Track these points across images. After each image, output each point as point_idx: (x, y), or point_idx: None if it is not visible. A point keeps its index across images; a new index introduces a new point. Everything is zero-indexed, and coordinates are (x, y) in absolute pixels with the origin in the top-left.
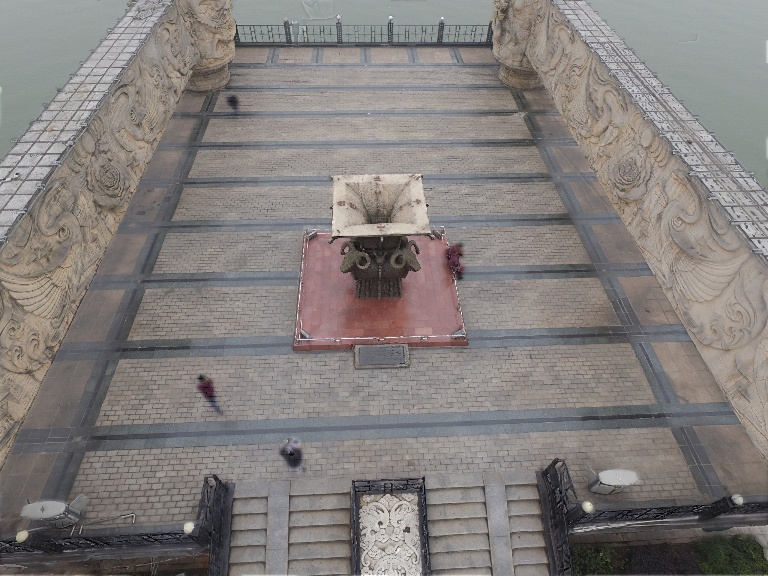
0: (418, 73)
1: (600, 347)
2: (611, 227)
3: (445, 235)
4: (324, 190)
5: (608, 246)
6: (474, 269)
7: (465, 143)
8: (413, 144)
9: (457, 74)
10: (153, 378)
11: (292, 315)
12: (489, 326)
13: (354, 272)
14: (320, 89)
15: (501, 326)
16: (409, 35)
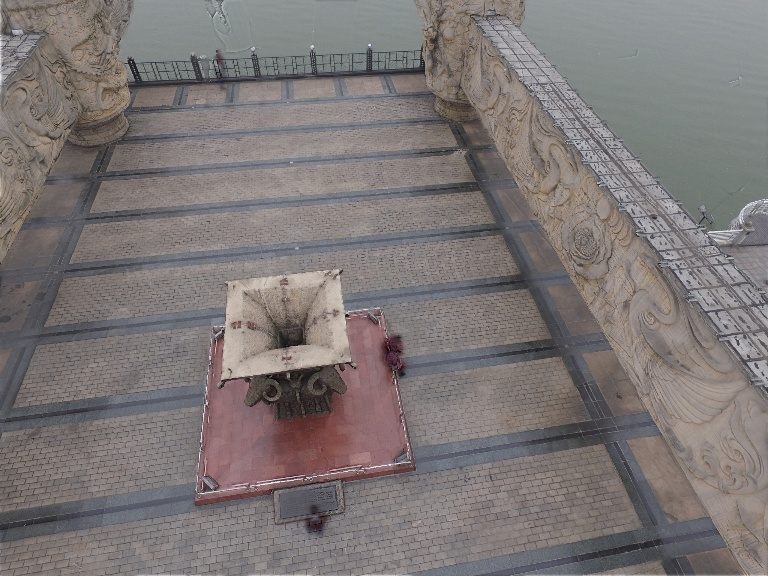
0: (347, 108)
1: (570, 454)
2: (569, 288)
3: (382, 319)
4: (238, 267)
5: (568, 313)
6: (418, 360)
7: (402, 192)
8: (343, 198)
9: (390, 107)
10: (2, 575)
11: (195, 451)
12: (439, 439)
13: (265, 399)
14: (235, 135)
15: (453, 437)
16: (335, 64)
